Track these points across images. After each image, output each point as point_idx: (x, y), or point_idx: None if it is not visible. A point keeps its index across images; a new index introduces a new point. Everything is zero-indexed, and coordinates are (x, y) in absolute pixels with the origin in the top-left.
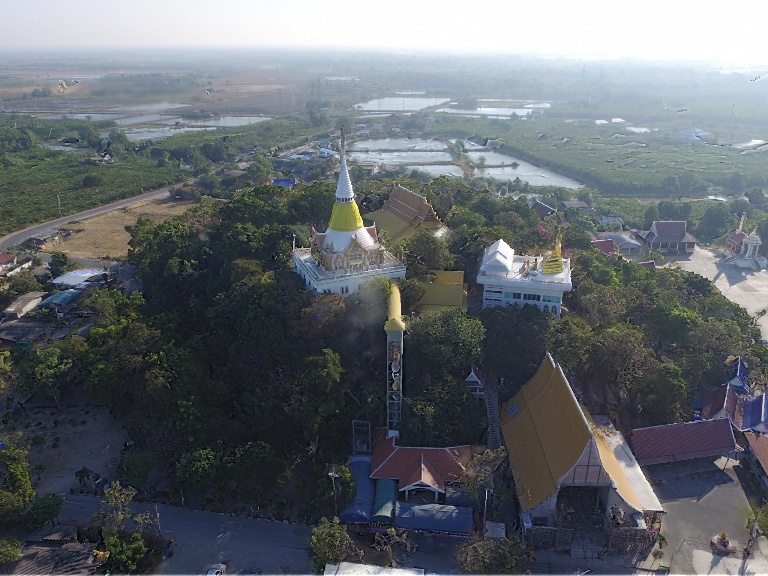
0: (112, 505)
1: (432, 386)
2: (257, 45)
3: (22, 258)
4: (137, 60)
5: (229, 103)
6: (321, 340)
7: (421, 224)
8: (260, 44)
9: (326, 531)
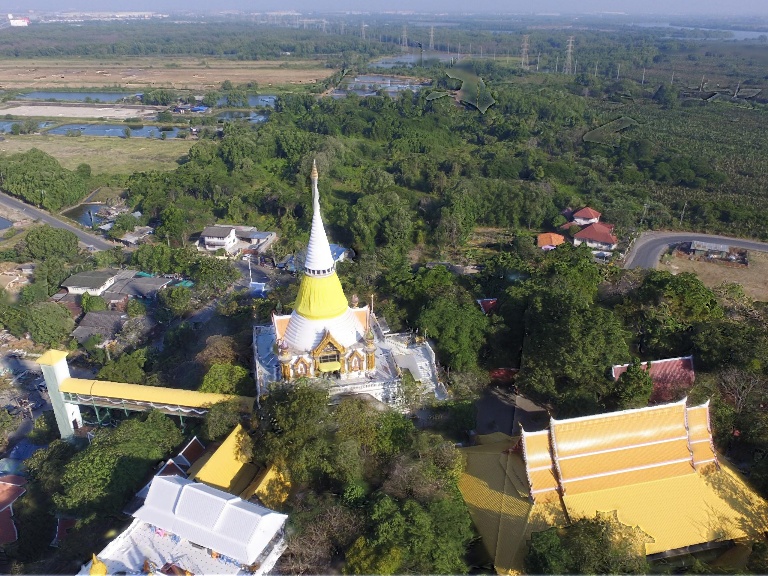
0: (124, 327)
1: (64, 466)
2: None
3: (621, 247)
4: (722, 47)
5: (628, 123)
6: (195, 369)
7: (513, 455)
8: None
9: (0, 417)
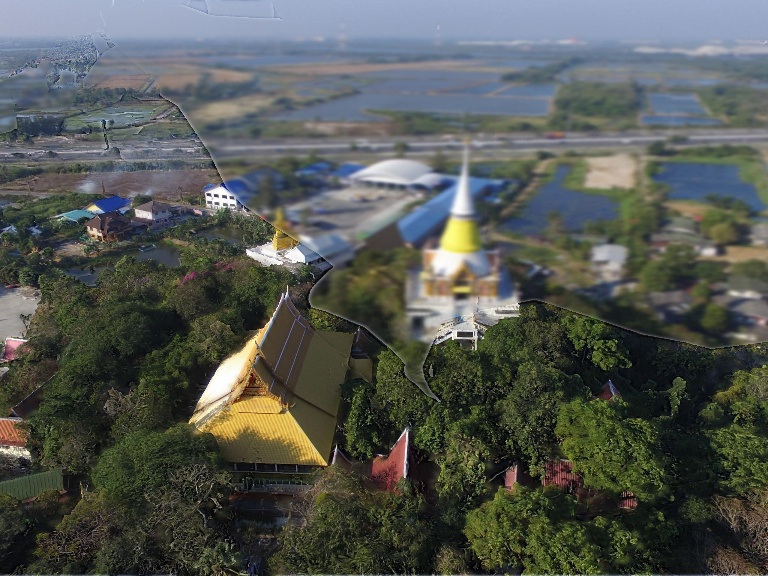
0: None
1: None
2: (660, 58)
3: None
4: None
5: None
6: None
7: None
8: (635, 50)
9: None
